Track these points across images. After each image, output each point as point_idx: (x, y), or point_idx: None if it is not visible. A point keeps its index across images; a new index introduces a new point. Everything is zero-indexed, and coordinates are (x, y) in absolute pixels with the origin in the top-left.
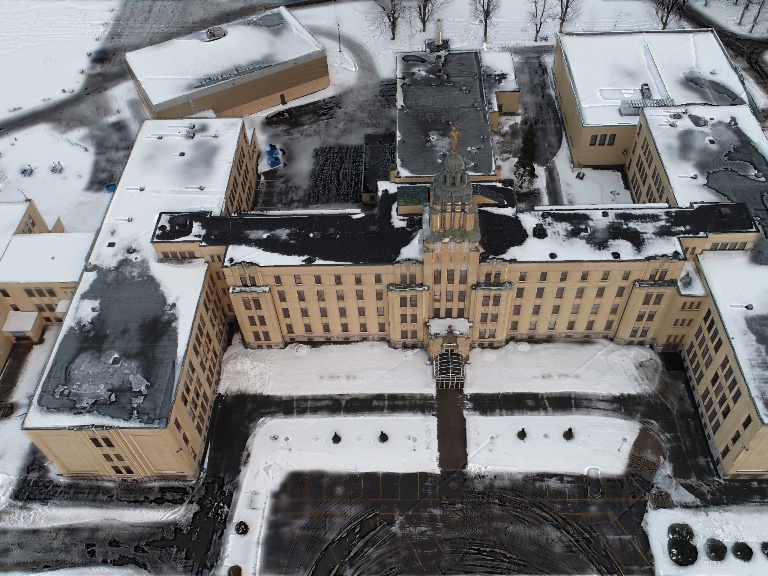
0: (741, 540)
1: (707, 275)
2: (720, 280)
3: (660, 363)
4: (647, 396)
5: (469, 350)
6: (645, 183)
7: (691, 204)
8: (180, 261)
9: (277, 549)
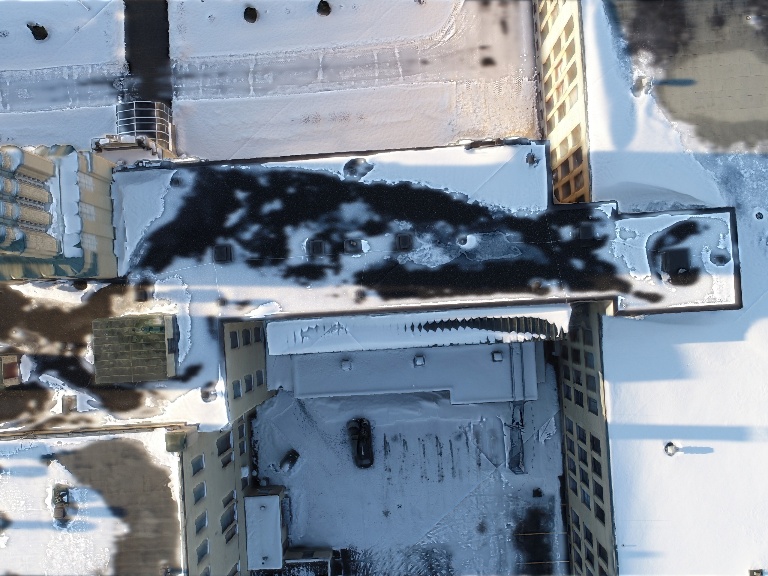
0: None
1: None
2: None
3: None
4: None
5: None
6: None
7: None
8: None
9: None
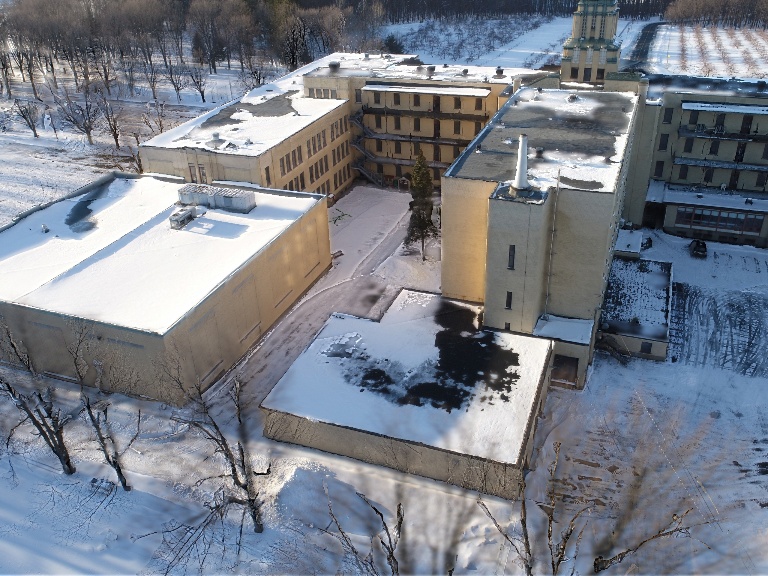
0: None
1: None
2: None
3: None
4: None
5: None
6: None
7: None
8: None
9: None
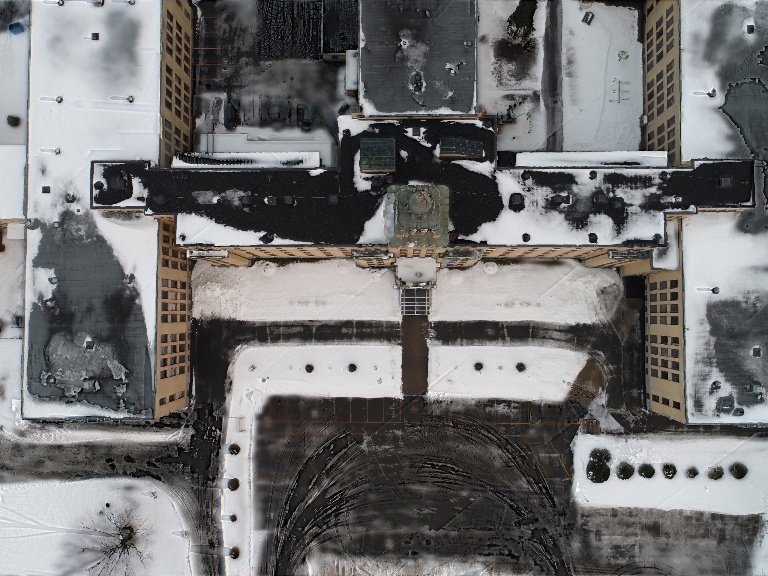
0: (648, 462)
1: (685, 248)
2: (697, 255)
3: (622, 289)
4: (601, 326)
5: None
6: (659, 62)
7: (692, 162)
8: (127, 215)
9: (266, 463)
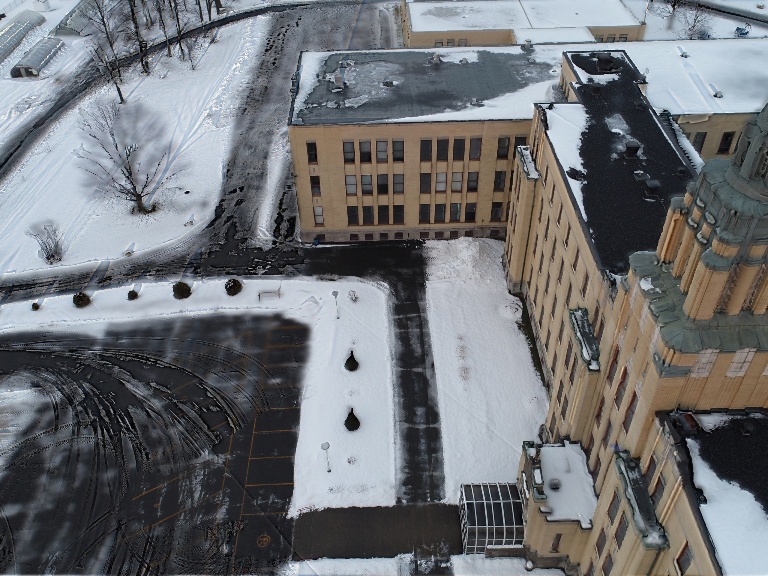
0: None
1: None
2: None
3: None
4: None
5: (564, 568)
6: None
7: None
8: (561, 99)
9: (206, 328)
